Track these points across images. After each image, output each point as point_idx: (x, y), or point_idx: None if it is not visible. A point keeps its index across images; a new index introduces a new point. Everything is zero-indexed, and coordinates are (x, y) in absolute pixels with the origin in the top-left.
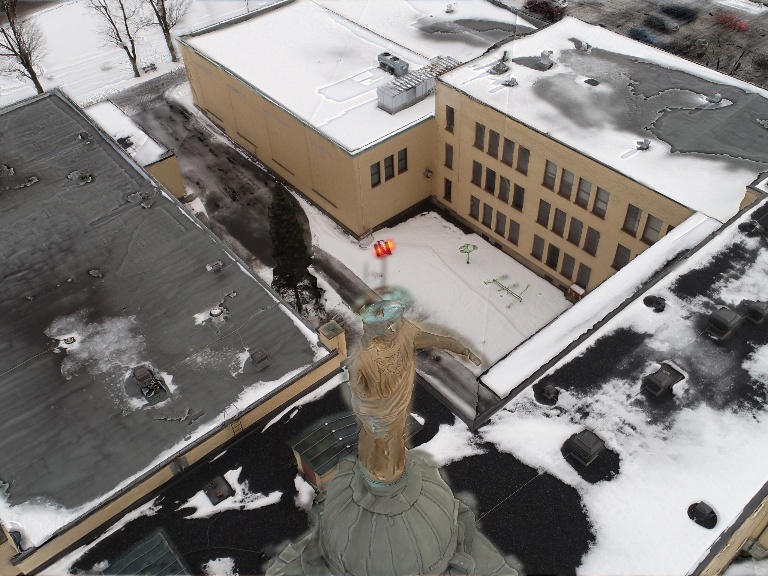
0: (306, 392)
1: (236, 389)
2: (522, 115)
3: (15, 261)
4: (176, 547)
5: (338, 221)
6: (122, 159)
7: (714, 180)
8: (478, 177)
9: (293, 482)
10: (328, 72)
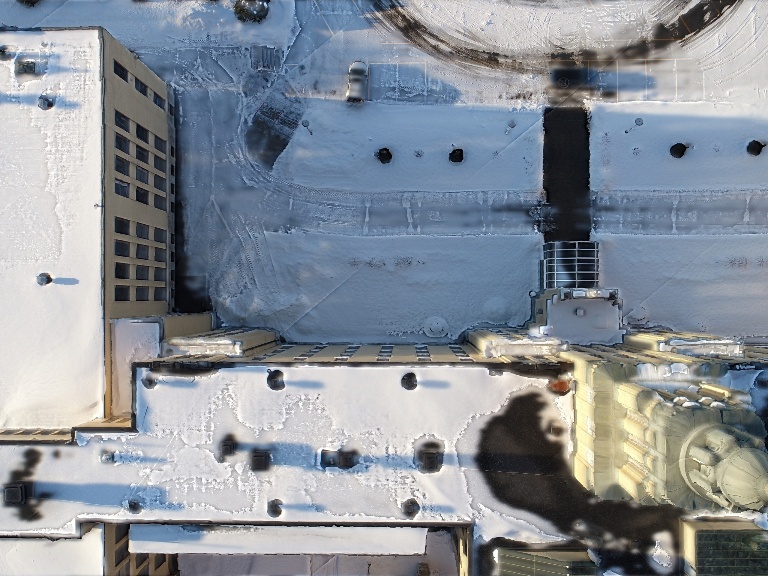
0: None
1: None
2: None
3: None
4: None
5: None
6: None
7: (45, 573)
8: None
9: None
10: None
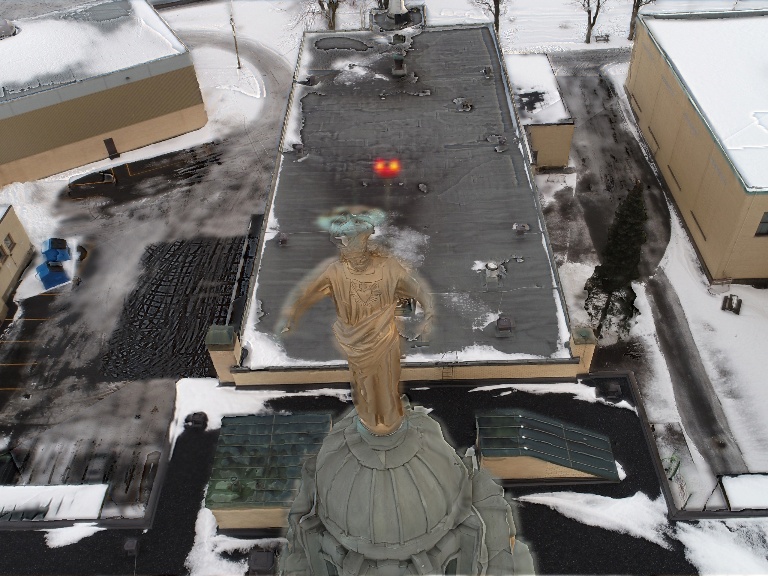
0: (529, 381)
1: (467, 341)
2: None
3: (373, 151)
4: None
5: (700, 254)
6: (506, 102)
7: None
8: None
9: (466, 449)
10: None
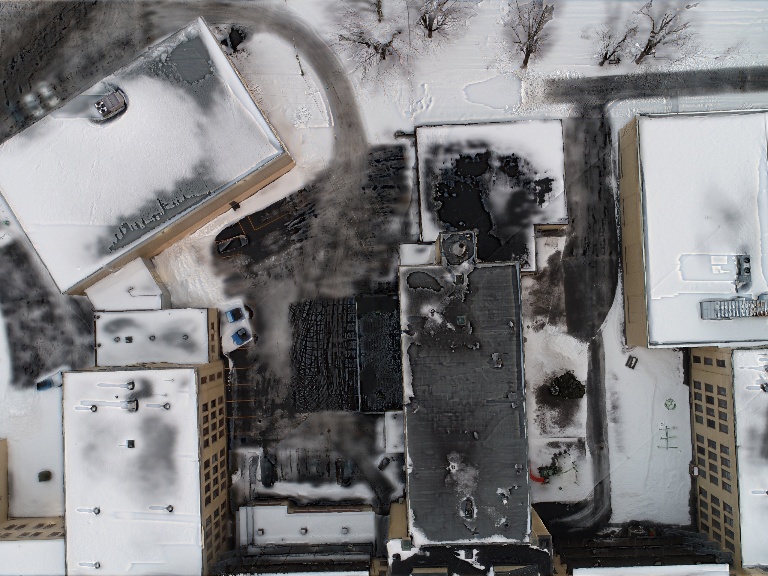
0: None
1: (493, 532)
2: (742, 422)
3: (451, 404)
4: (449, 562)
5: (625, 323)
6: (520, 360)
7: None
8: (709, 387)
9: (490, 567)
10: (703, 236)
